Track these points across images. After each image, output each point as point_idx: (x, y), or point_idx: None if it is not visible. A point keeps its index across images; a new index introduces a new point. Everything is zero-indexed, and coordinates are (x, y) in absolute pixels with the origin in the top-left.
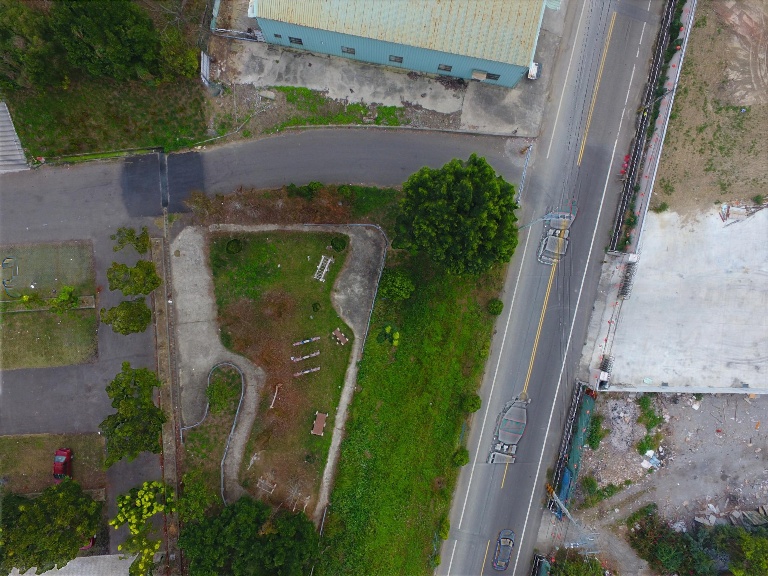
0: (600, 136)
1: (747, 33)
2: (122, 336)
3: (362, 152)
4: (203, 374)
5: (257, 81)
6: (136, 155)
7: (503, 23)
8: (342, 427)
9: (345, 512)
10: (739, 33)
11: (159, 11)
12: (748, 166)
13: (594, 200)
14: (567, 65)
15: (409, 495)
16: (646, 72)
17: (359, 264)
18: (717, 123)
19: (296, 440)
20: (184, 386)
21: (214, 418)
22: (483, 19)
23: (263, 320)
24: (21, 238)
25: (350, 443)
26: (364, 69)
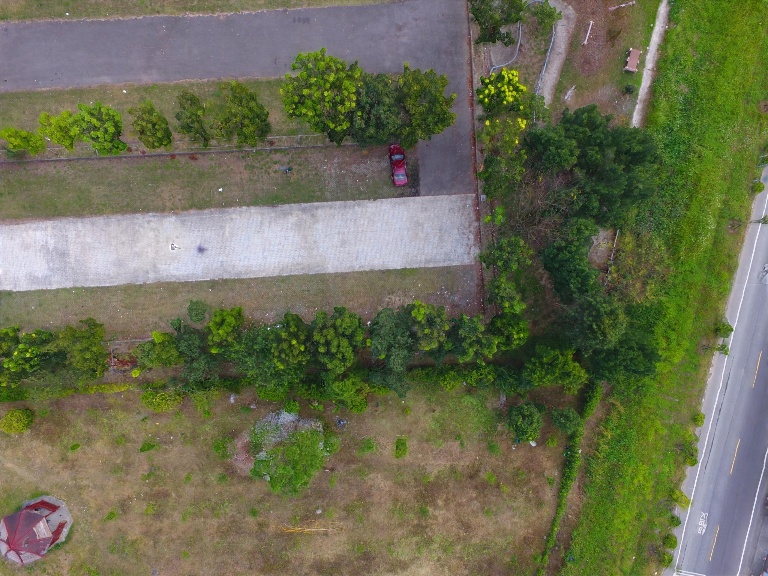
0: None
1: None
2: None
3: None
4: None
5: None
6: None
7: None
8: (652, 67)
9: (660, 147)
10: None
11: None
12: None
13: None
14: None
15: (737, 117)
16: None
17: None
18: None
19: (607, 79)
20: None
21: (524, 58)
22: None
23: None
24: None
25: (666, 77)
26: None
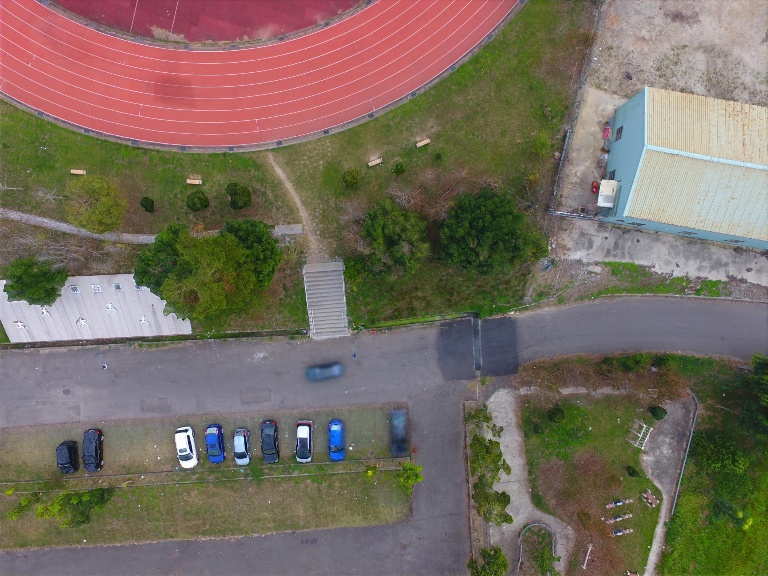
0: None
1: None
2: (436, 496)
3: (680, 321)
4: (513, 533)
5: (586, 257)
6: (451, 320)
7: None
8: None
9: None
10: None
11: (520, 205)
12: None
13: None
14: None
15: None
16: None
17: (668, 426)
18: None
19: None
20: (494, 544)
21: (525, 575)
22: None
23: (574, 481)
24: (340, 401)
25: None
26: (690, 244)
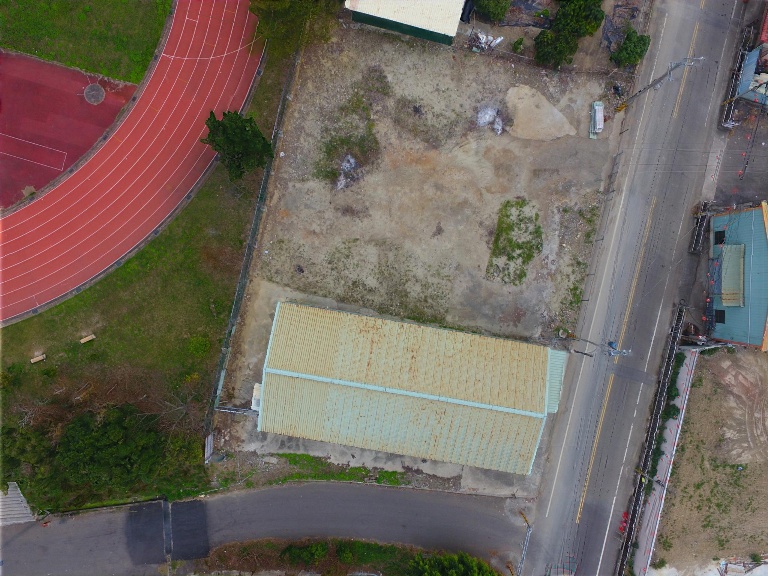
0: (599, 494)
1: (743, 393)
2: None
3: (363, 508)
4: None
5: (260, 449)
6: (140, 504)
7: (502, 440)
8: None
9: None
10: (735, 393)
11: (164, 414)
12: (745, 523)
13: (593, 556)
14: (566, 426)
15: None
16: (644, 431)
17: None
18: (714, 480)
19: None
20: None
21: None
22: (482, 437)
23: None
24: None
25: None
26: None
